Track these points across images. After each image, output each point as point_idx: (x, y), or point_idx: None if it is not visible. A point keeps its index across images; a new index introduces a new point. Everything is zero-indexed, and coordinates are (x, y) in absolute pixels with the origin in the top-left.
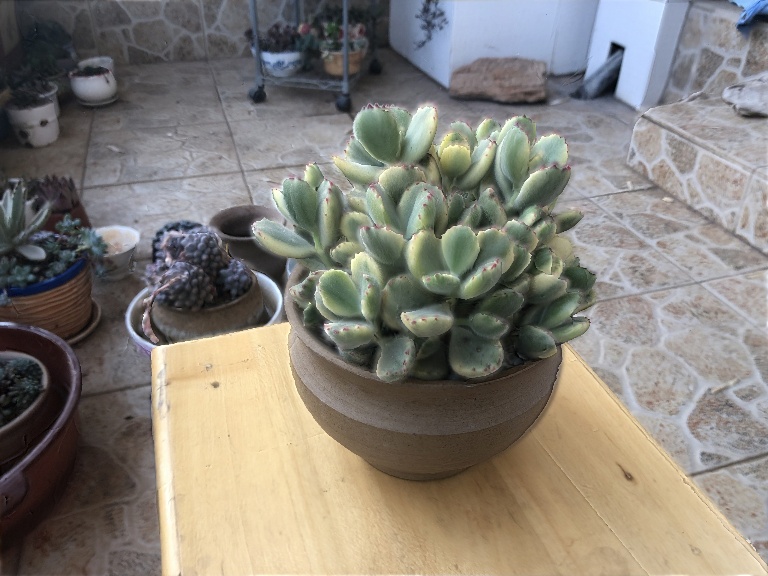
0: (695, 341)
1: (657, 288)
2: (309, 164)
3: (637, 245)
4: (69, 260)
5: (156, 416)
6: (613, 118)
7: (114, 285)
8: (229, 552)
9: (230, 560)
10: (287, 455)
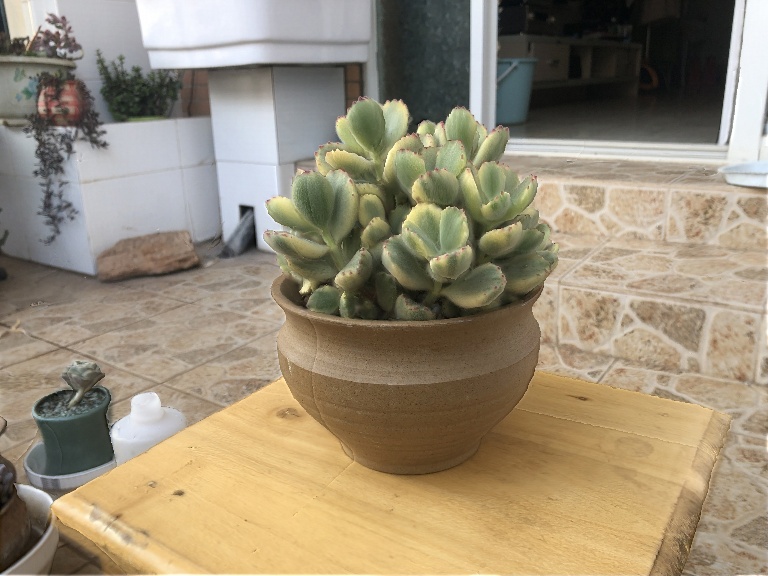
0: None
1: None
2: None
3: None
4: None
5: (130, 552)
6: (267, 264)
7: None
8: None
9: None
10: (324, 505)
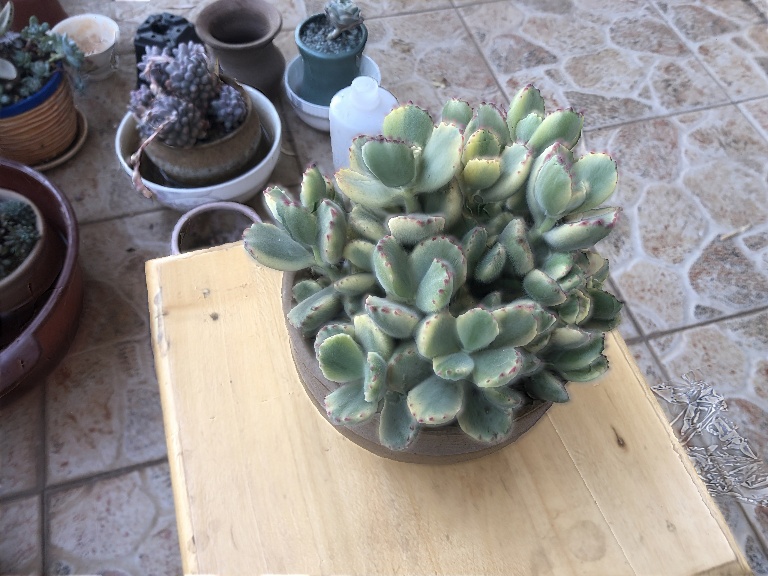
0: (716, 178)
1: (688, 109)
2: None
3: (676, 50)
4: (43, 75)
5: (157, 351)
6: None
7: (97, 86)
8: (237, 516)
9: (238, 525)
10: (289, 407)
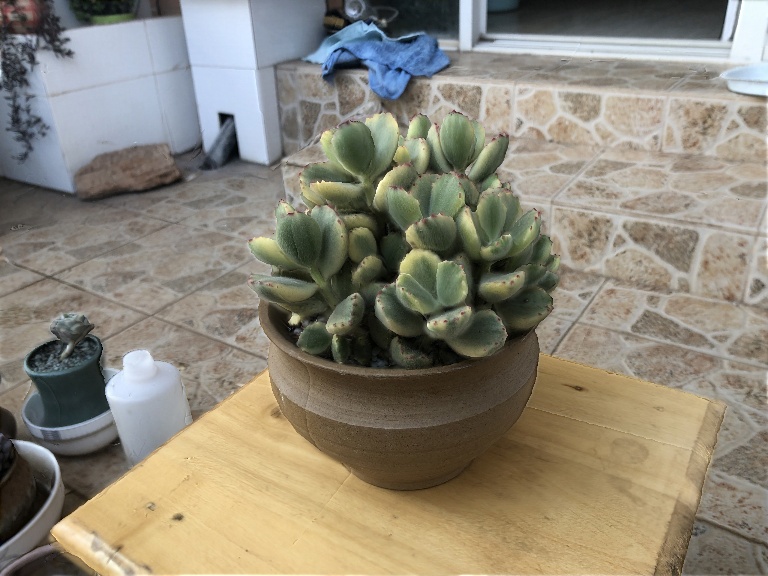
0: None
1: None
2: (281, 201)
3: None
4: None
5: None
6: (251, 177)
7: None
8: None
9: None
10: (323, 530)
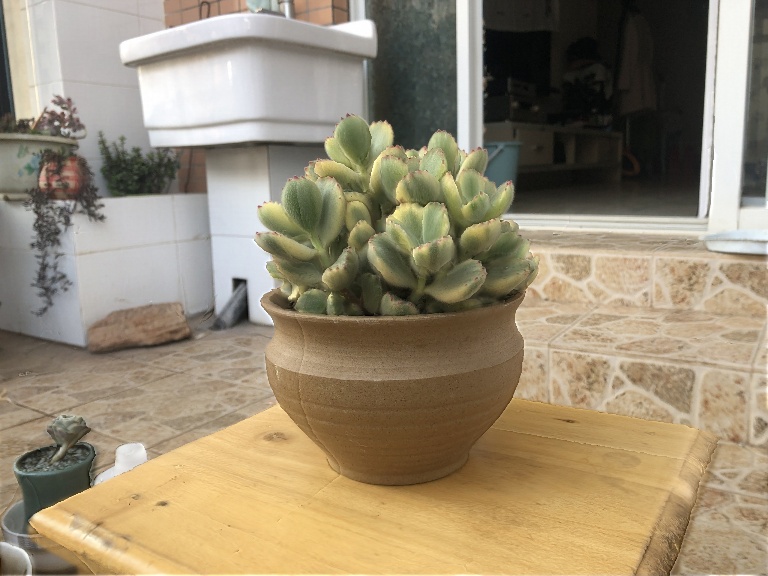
0: None
1: None
2: None
3: None
4: None
5: (109, 557)
6: (258, 336)
7: None
8: None
9: None
10: (309, 512)
